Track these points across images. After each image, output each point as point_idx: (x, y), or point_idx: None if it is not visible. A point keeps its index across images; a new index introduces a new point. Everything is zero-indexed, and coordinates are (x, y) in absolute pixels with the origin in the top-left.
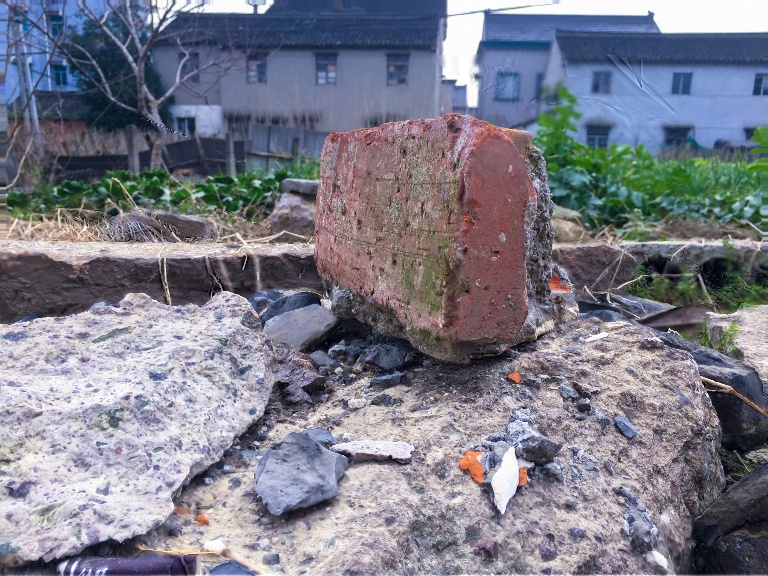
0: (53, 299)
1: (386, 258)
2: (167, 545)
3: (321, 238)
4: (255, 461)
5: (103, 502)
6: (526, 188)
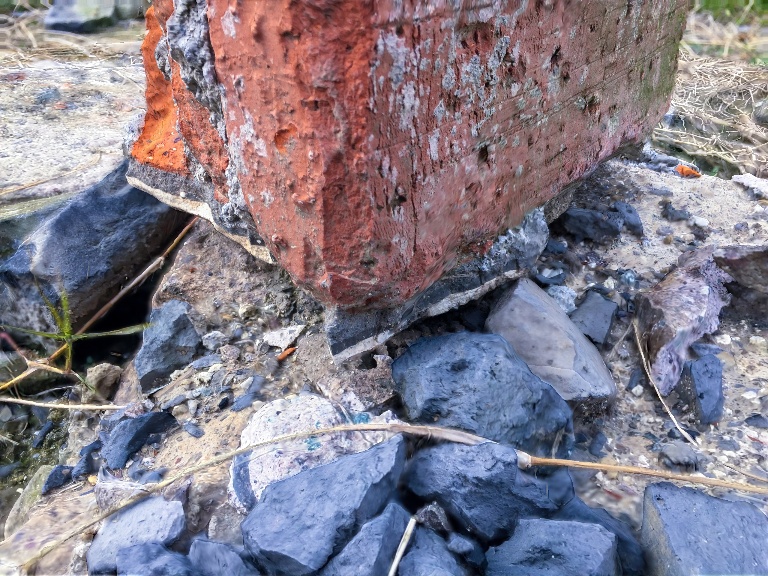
0: None
1: (620, 86)
2: None
3: (430, 196)
4: None
5: None
6: None
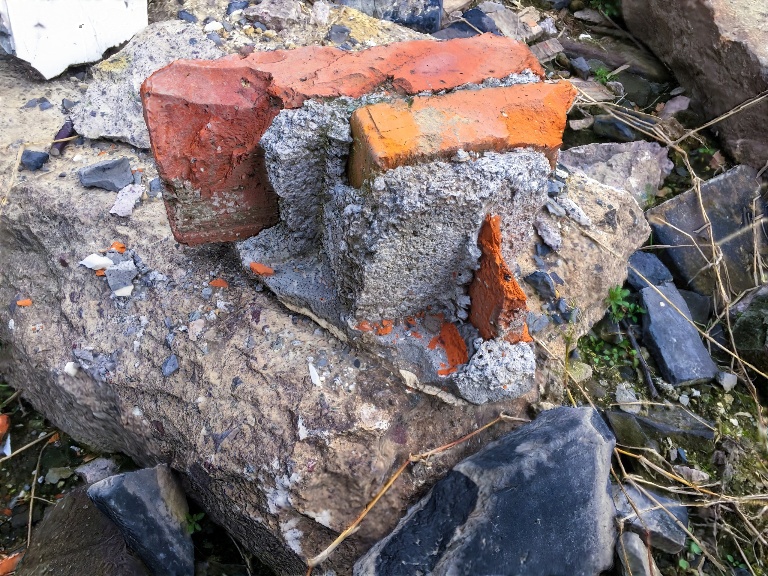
0: (695, 57)
1: None
2: (88, 146)
3: None
4: (150, 164)
5: (93, 115)
6: (153, 150)
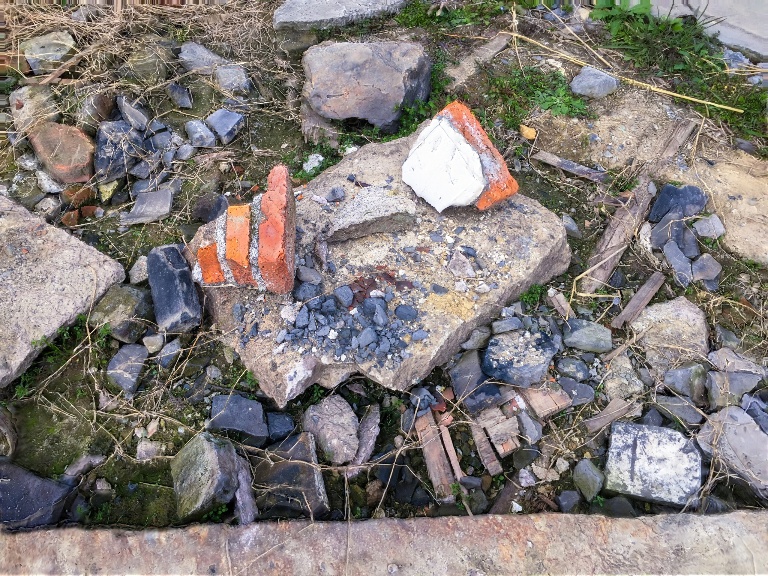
0: None
1: None
2: None
3: None
4: None
5: None
6: None
